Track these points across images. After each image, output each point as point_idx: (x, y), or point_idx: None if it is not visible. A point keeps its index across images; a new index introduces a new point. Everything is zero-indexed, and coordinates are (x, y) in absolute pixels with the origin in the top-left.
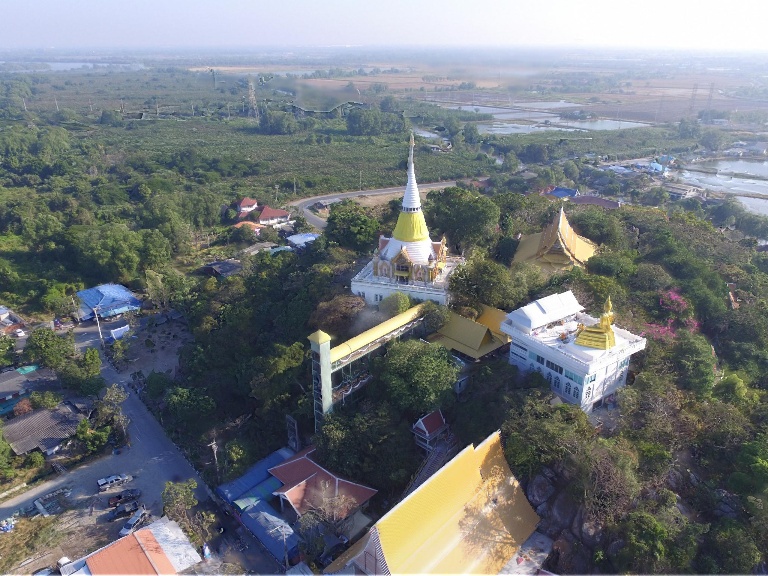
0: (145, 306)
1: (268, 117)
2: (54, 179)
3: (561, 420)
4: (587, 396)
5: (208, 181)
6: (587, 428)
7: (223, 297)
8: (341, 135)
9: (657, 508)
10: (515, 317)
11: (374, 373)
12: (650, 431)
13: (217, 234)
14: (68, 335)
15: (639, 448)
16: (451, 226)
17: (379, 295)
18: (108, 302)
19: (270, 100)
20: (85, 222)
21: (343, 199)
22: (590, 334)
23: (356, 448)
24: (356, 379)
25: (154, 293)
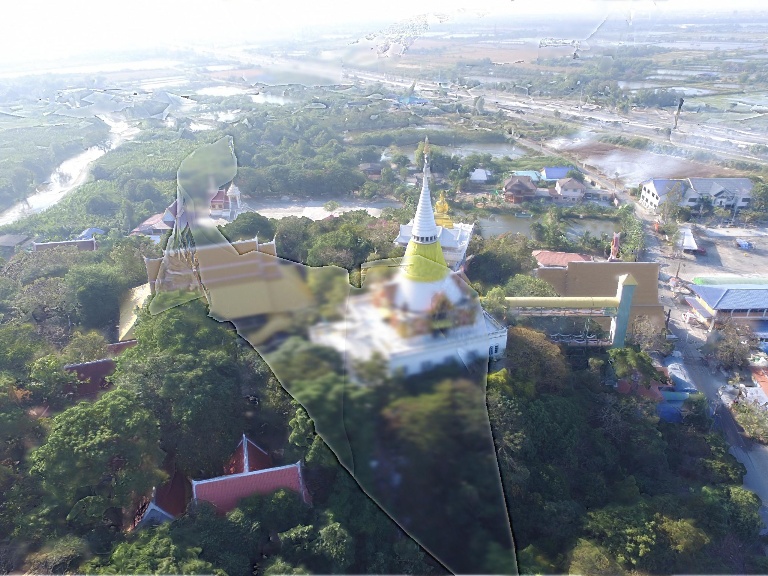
0: None
1: None
2: None
3: None
4: None
5: None
6: None
7: (626, 574)
8: None
9: None
10: None
11: None
12: None
13: None
14: None
15: None
16: None
17: None
18: None
19: None
20: None
21: None
22: None
23: None
24: None
25: None
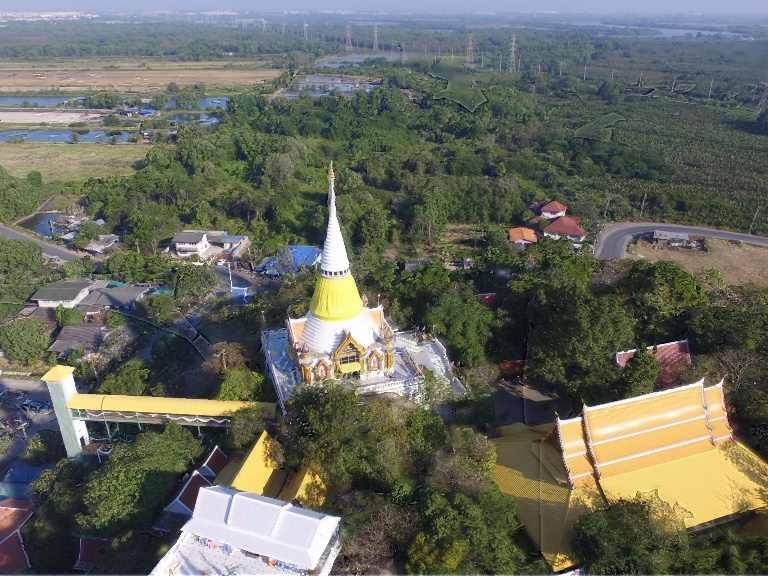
0: None
1: None
2: (454, 141)
3: None
4: None
5: (579, 174)
6: None
7: None
8: None
9: None
10: None
11: None
12: None
13: (488, 232)
14: (209, 277)
15: None
16: None
17: None
18: None
19: None
20: (404, 186)
21: (696, 237)
22: None
23: None
24: None
25: (280, 267)
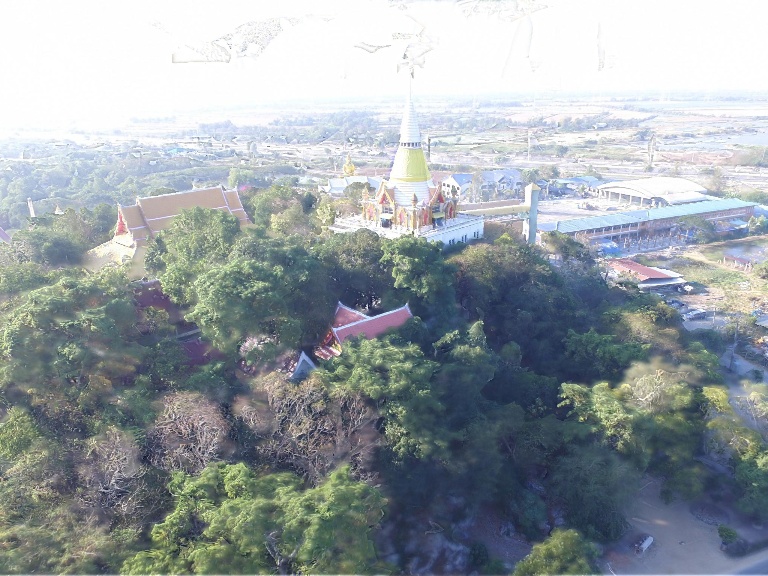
0: None
1: None
2: None
3: None
4: None
5: None
6: None
7: None
8: None
9: None
10: None
11: None
12: None
13: None
14: None
15: None
16: None
17: None
18: None
19: None
20: None
21: None
22: None
23: None
24: None
25: None
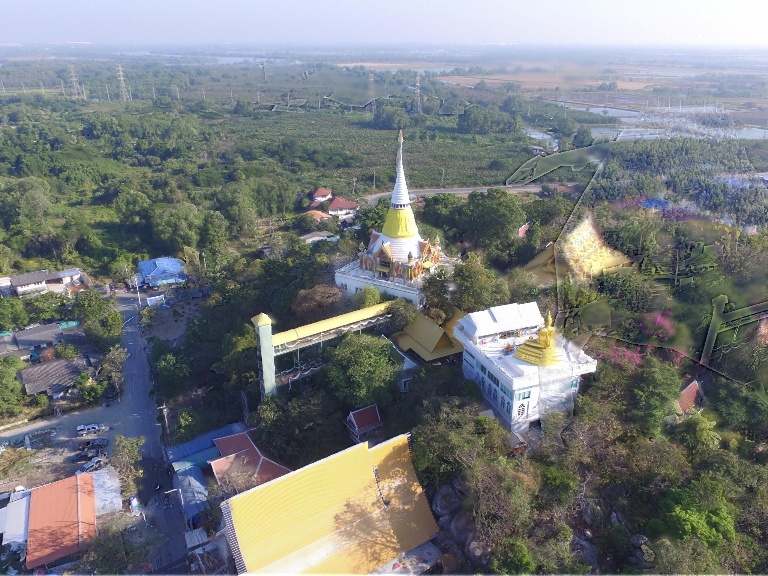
0: (193, 280)
1: (381, 112)
2: (169, 161)
3: (472, 432)
4: (520, 413)
5: (301, 170)
6: (499, 445)
7: (238, 277)
8: (448, 133)
9: (545, 540)
10: (465, 322)
11: (326, 362)
12: (568, 459)
13: (286, 220)
14: (111, 298)
15: (545, 474)
16: (473, 227)
17: (359, 288)
18: (159, 273)
19: (395, 96)
20: (176, 201)
21: (419, 195)
22: (529, 348)
23: (285, 431)
24: (310, 366)
25: (190, 268)
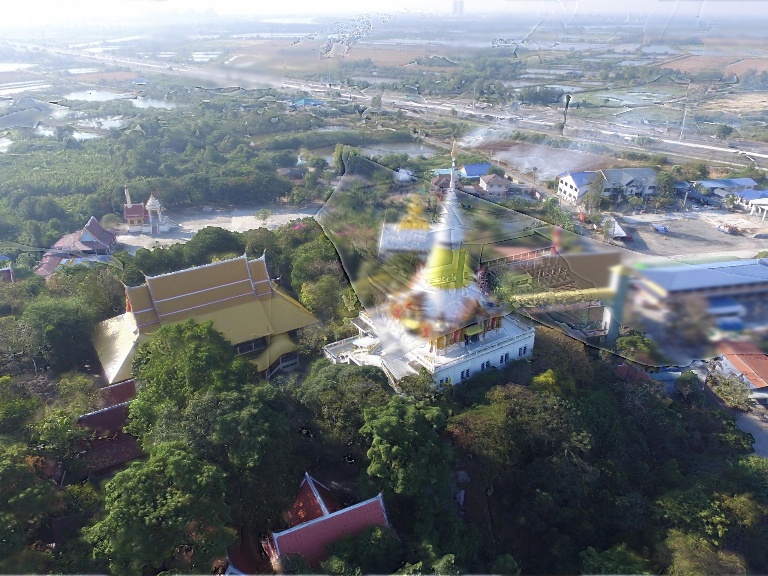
0: None
1: None
2: None
3: None
4: None
5: None
6: None
7: None
8: None
9: None
10: None
11: None
12: None
13: None
14: None
15: None
16: None
17: None
18: None
19: None
20: None
21: None
22: None
23: None
24: None
25: None
